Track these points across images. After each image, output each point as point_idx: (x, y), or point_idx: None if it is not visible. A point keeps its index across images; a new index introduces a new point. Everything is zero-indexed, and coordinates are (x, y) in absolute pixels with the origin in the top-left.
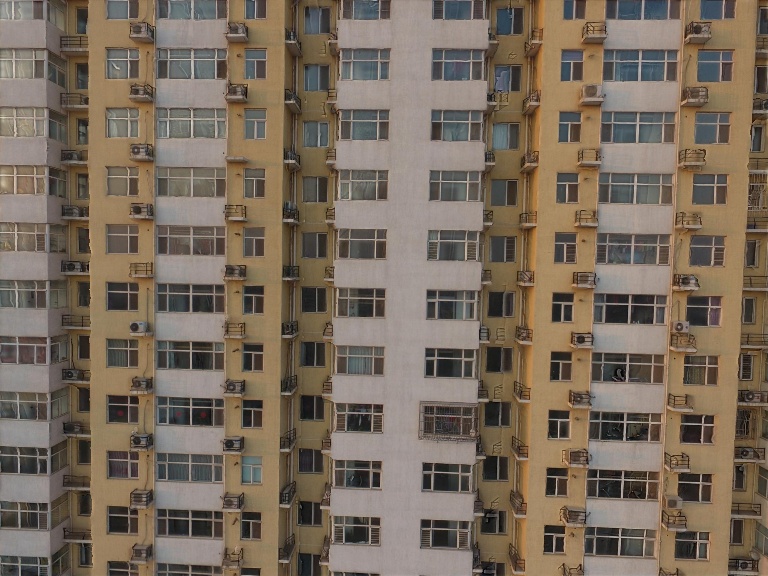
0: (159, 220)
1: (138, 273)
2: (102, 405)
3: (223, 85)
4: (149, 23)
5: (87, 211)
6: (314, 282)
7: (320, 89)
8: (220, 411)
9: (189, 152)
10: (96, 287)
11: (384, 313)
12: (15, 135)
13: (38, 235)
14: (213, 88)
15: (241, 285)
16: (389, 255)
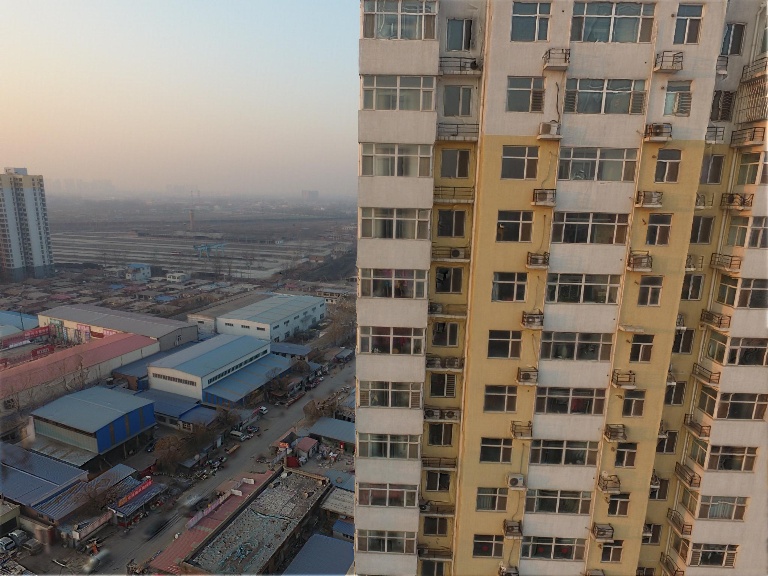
0: (541, 382)
1: (524, 435)
2: (470, 543)
3: (622, 251)
4: (549, 185)
5: (450, 362)
6: (667, 427)
7: (699, 241)
8: (582, 548)
9: (578, 318)
10: (472, 442)
11: (752, 467)
12: (393, 296)
13: (413, 393)
14: (611, 254)
15: (616, 442)
16: (767, 417)
